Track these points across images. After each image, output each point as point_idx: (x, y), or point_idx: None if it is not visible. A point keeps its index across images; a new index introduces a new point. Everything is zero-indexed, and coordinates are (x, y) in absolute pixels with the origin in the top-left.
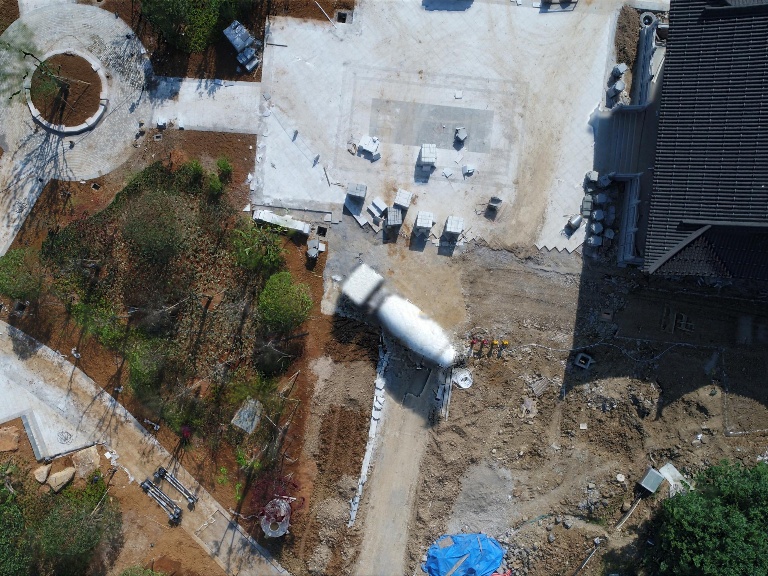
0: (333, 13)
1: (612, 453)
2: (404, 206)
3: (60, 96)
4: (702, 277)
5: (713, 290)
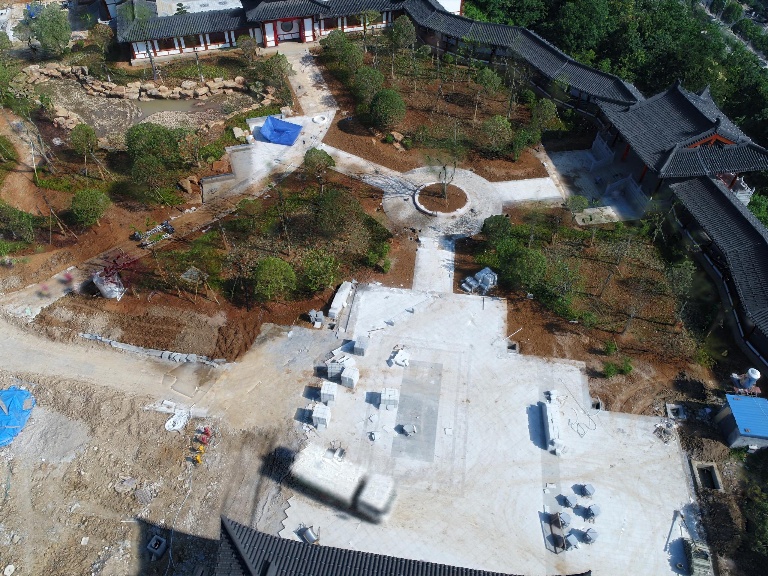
0: (515, 341)
1: (41, 571)
2: (343, 373)
3: (438, 194)
4: None
5: None
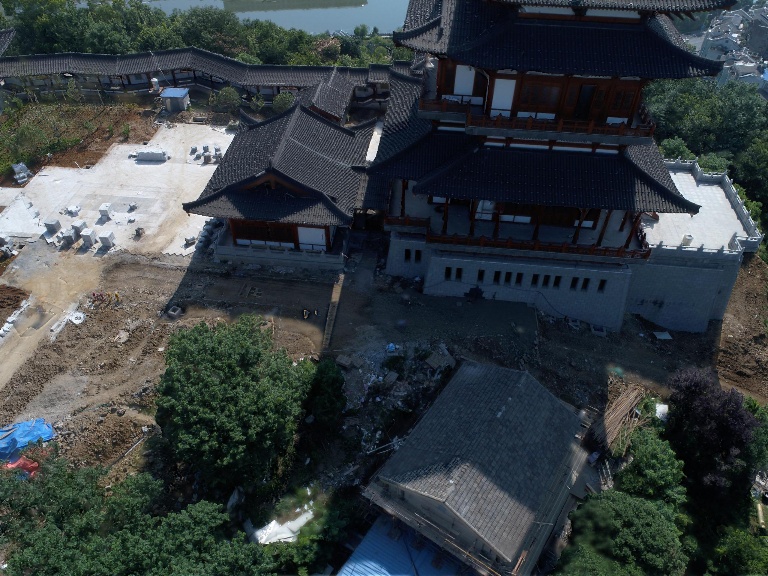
0: (83, 166)
1: None
2: (77, 227)
3: None
4: (272, 268)
5: (279, 275)
